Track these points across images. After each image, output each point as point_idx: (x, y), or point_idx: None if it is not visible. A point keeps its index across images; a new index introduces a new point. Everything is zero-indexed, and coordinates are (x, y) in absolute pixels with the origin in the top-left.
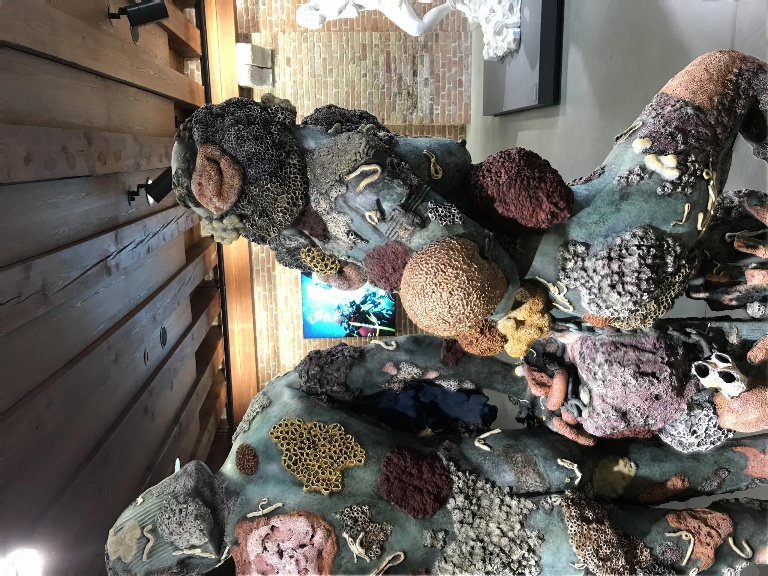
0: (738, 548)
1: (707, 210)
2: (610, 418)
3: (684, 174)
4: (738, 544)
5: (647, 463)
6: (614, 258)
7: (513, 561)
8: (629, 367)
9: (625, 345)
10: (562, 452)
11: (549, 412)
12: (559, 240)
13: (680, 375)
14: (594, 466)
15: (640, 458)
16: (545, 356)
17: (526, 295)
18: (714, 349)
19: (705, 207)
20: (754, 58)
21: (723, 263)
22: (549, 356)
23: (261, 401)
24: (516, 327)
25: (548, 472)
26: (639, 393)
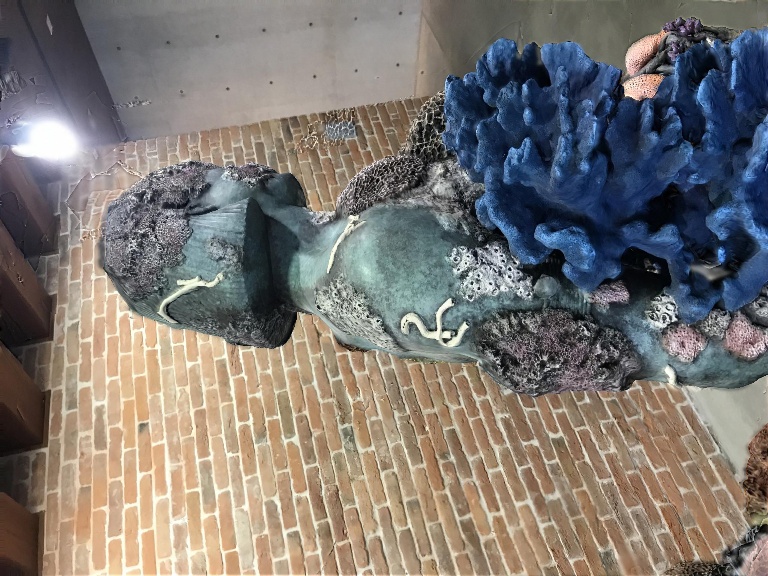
0: None
1: None
2: None
3: None
4: None
5: None
6: None
7: None
8: None
9: None
10: None
11: None
12: None
13: None
14: None
15: None
16: None
17: None
18: None
19: None
20: None
21: None
22: None
23: (391, 349)
24: None
25: None
26: None
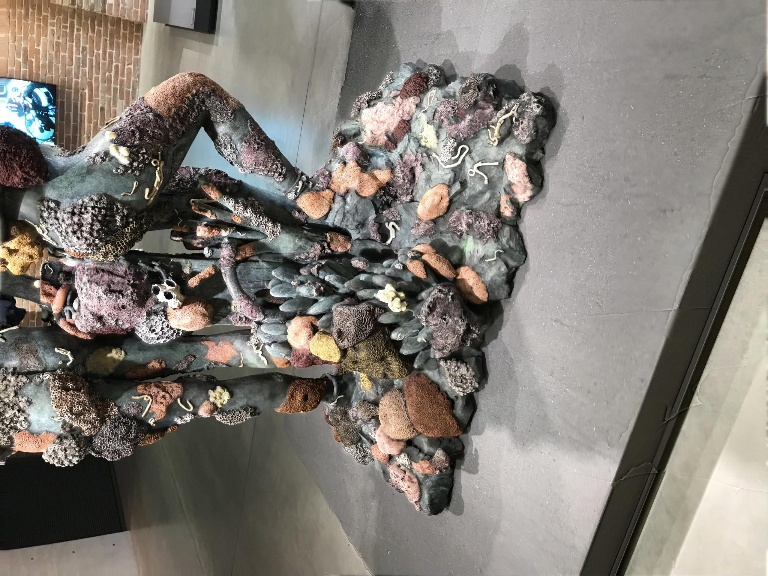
0: (183, 405)
1: (154, 186)
2: (89, 320)
3: (136, 161)
4: (184, 402)
5: (134, 351)
6: (76, 213)
7: (6, 418)
8: (102, 286)
9: (104, 271)
10: (61, 343)
11: (58, 315)
12: (38, 196)
13: (142, 293)
14: (89, 353)
15: (130, 348)
16: (62, 274)
17: (17, 232)
18: (170, 277)
19: (152, 184)
20: (213, 83)
21: (185, 219)
22: (66, 274)
23: None
24: (9, 254)
25: (46, 357)
26: (109, 304)
